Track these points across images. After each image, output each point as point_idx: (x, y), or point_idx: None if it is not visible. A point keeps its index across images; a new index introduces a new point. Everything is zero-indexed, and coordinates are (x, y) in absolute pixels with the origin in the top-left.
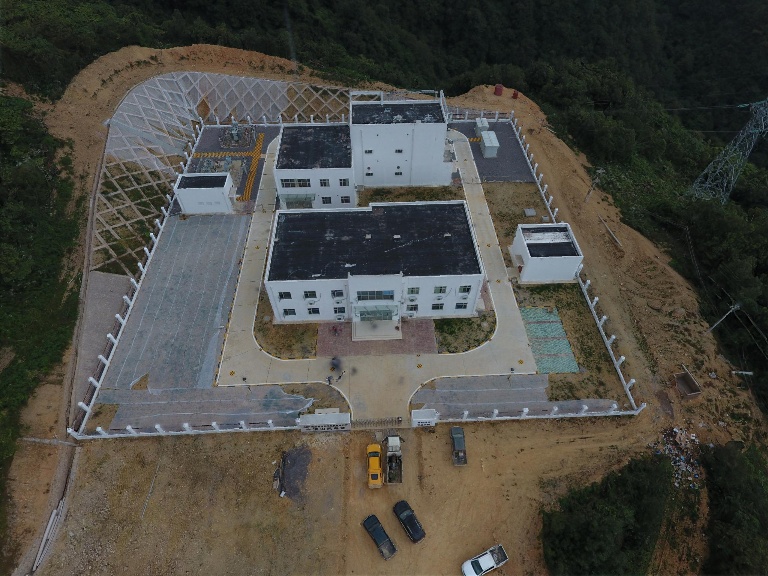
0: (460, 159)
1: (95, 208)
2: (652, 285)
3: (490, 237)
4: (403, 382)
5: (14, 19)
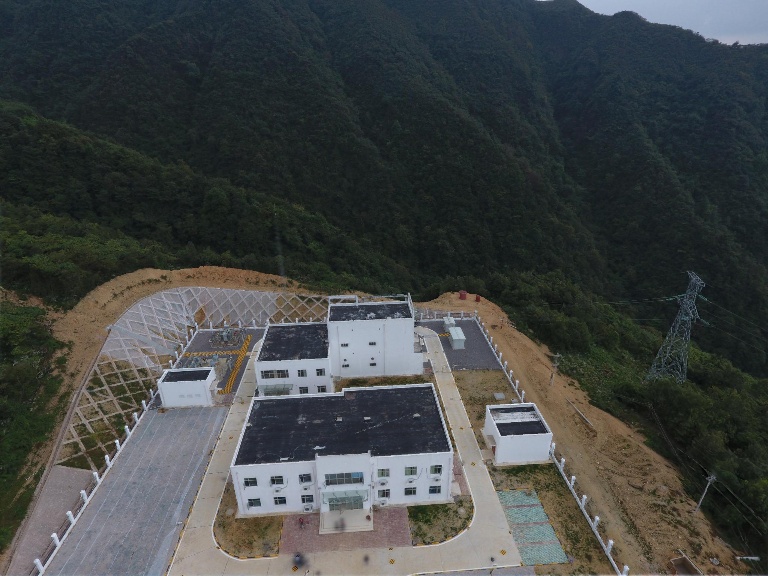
0: (431, 351)
1: (77, 403)
2: (629, 463)
3: (462, 420)
4: None
5: (52, 250)
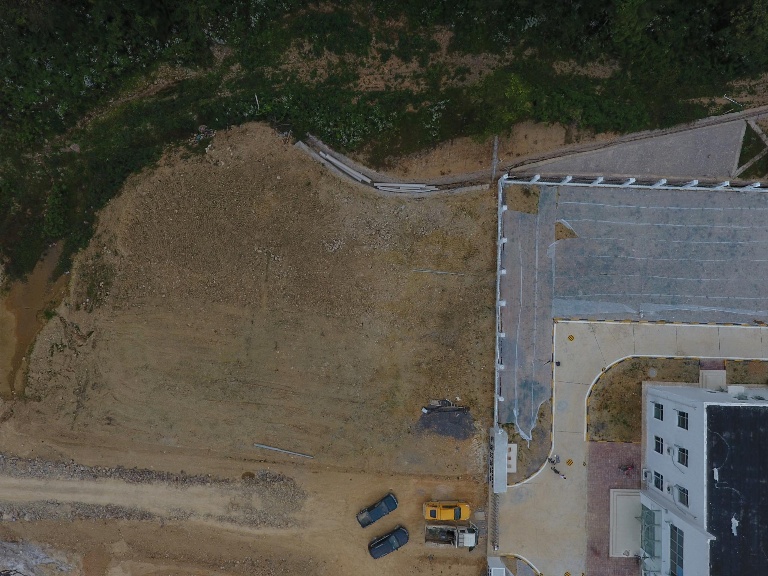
0: None
1: None
2: None
3: None
4: (546, 552)
5: None
